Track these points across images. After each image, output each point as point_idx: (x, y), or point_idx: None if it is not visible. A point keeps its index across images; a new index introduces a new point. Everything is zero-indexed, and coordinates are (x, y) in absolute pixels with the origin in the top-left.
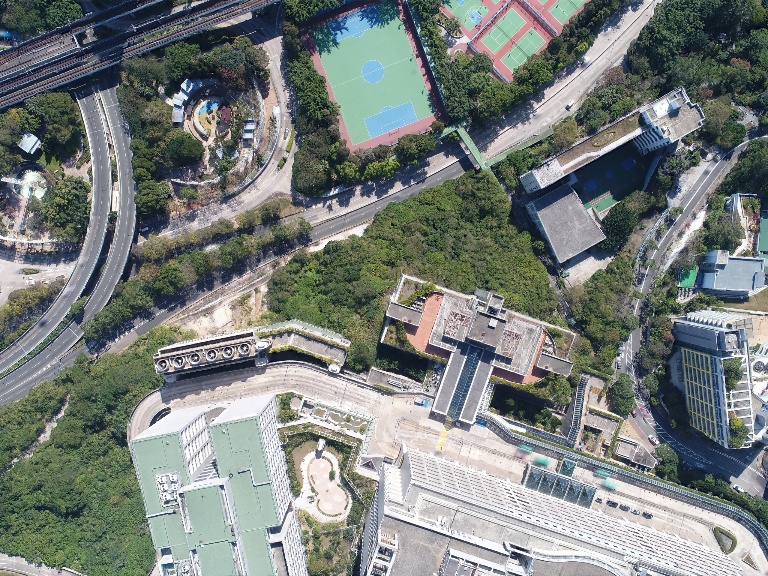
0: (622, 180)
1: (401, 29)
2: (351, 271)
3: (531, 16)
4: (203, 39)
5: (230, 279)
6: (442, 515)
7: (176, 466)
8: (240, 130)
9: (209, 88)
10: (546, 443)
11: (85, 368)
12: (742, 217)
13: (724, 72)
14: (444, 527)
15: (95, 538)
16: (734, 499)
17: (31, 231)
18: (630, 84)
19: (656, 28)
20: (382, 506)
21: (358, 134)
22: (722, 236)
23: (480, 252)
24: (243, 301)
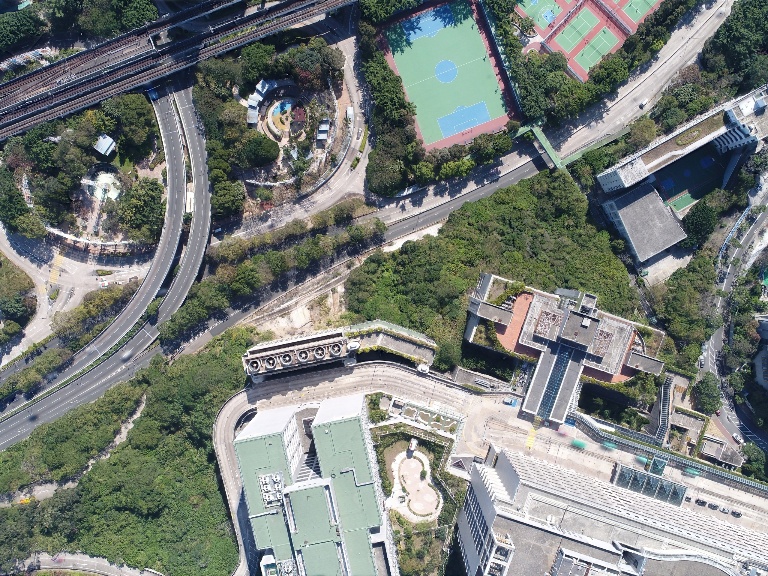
0: (700, 178)
1: (474, 29)
2: (431, 271)
3: (604, 15)
4: (277, 40)
5: (304, 279)
6: (551, 514)
7: (279, 466)
8: None
9: (283, 89)
10: (635, 442)
11: (161, 369)
12: None
13: None
14: (554, 526)
15: (176, 539)
16: None
17: (104, 232)
18: (706, 82)
19: (734, 26)
20: (489, 506)
21: (431, 134)
22: None
23: (558, 251)
24: (321, 301)
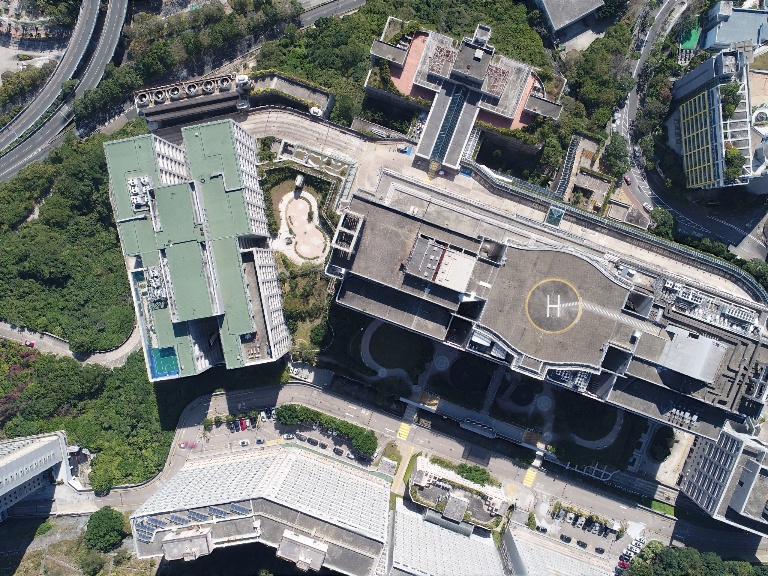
0: None
1: None
2: (339, 37)
3: None
4: None
5: (220, 64)
6: (414, 206)
7: (148, 170)
8: None
9: None
10: (533, 193)
11: (74, 146)
12: None
13: None
14: None
15: (77, 307)
16: (731, 260)
17: (26, 16)
18: None
19: None
20: None
21: None
22: None
23: (473, 25)
24: None
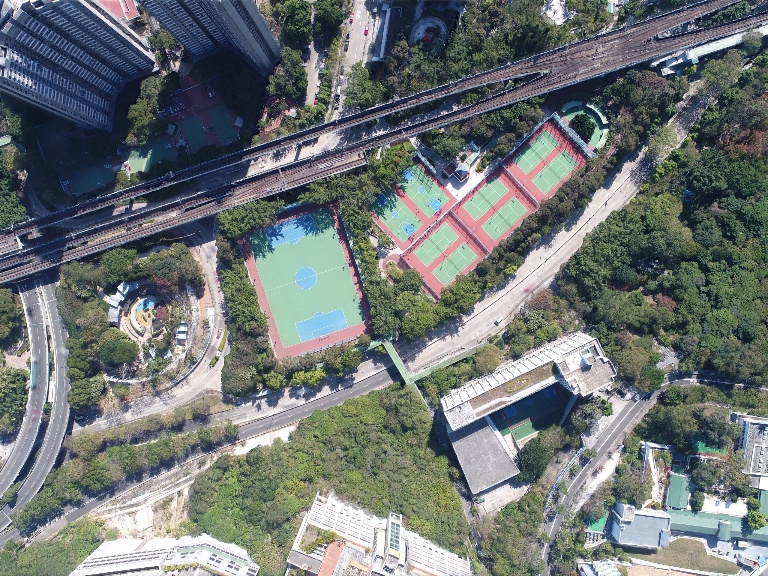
0: (542, 408)
1: (335, 238)
2: (267, 490)
3: (464, 231)
4: None
5: (158, 472)
6: None
7: None
8: (174, 329)
9: (146, 287)
10: None
11: (14, 555)
12: (653, 468)
13: (646, 314)
14: None
15: None
16: None
17: None
18: (557, 309)
19: (583, 260)
20: None
21: (289, 337)
22: (629, 492)
23: (397, 473)
24: (165, 506)
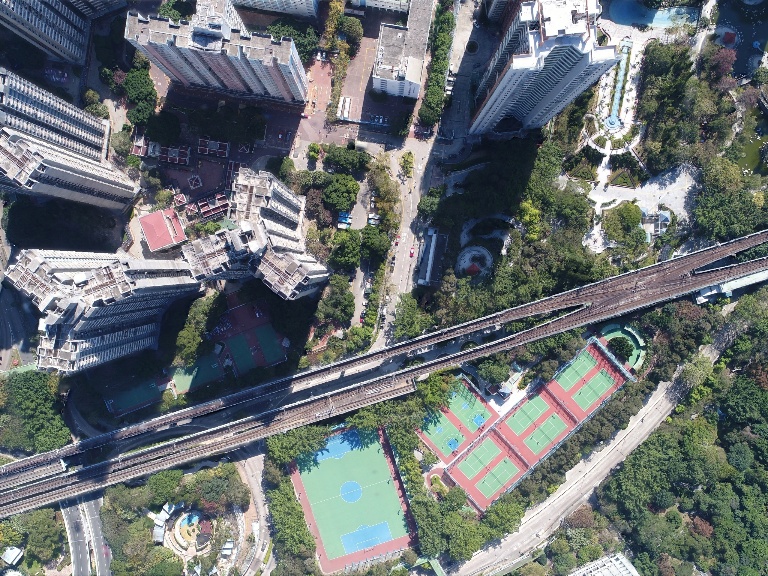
0: None
1: (380, 453)
2: None
3: (506, 446)
4: None
5: None
6: None
7: None
8: None
9: None
10: None
11: None
12: None
13: None
14: None
15: None
16: None
17: None
18: (598, 527)
19: (624, 486)
20: None
21: (334, 550)
22: None
23: None
24: None
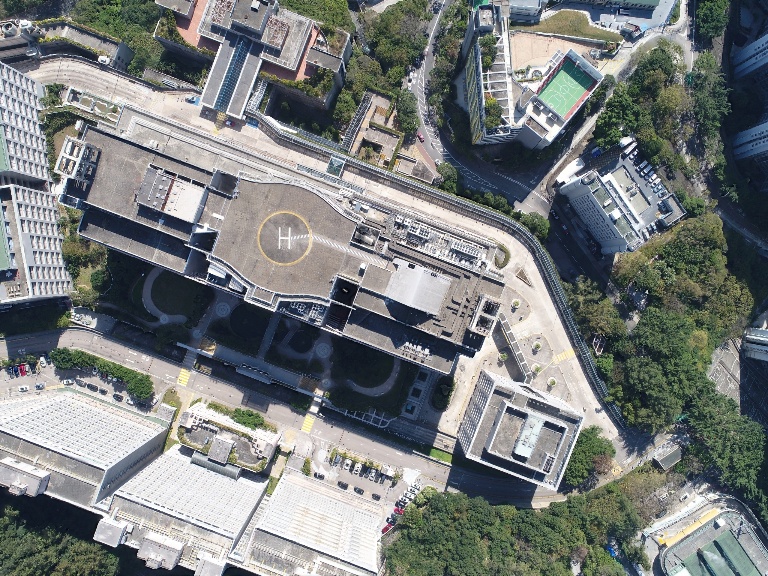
0: None
1: None
2: None
3: None
4: None
5: None
6: (155, 140)
7: None
8: None
9: None
10: (316, 144)
11: None
12: None
13: None
14: None
15: None
16: (509, 213)
17: None
18: None
19: None
20: None
21: None
22: None
23: None
24: None
